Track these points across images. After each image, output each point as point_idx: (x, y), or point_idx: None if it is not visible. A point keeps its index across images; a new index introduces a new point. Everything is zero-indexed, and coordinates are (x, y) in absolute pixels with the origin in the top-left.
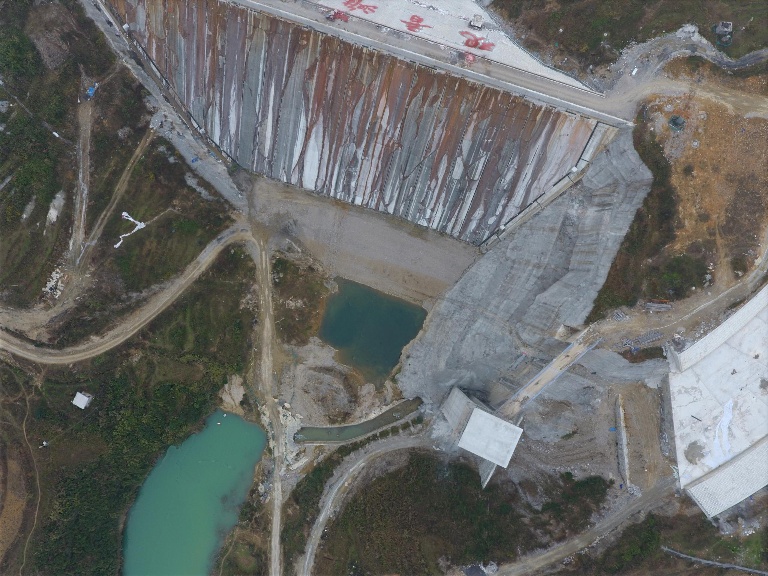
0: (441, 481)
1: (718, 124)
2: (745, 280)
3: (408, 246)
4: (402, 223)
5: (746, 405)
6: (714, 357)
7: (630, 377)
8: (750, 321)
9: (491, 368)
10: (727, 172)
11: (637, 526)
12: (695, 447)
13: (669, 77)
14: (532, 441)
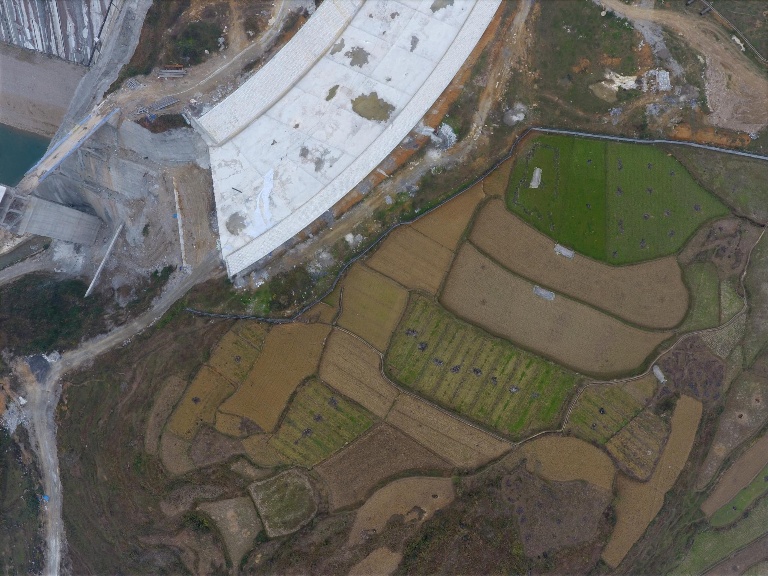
0: (37, 291)
1: None
2: (259, 40)
3: (20, 72)
4: (9, 48)
5: (287, 174)
6: (254, 129)
7: (180, 158)
8: (289, 91)
9: (69, 171)
10: None
11: (180, 298)
12: (236, 218)
13: None
14: (132, 248)
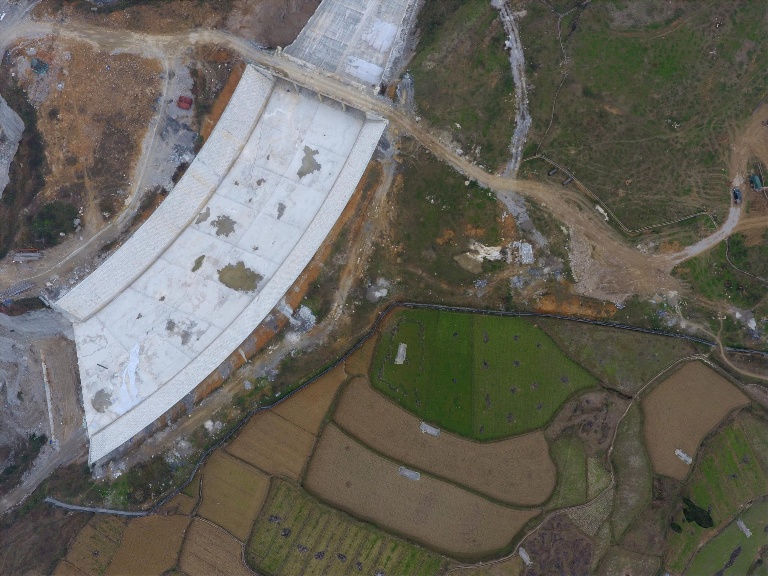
0: None
1: (83, 63)
2: (115, 221)
3: None
4: None
5: (153, 348)
6: (119, 303)
7: (46, 331)
8: (154, 263)
9: None
10: (93, 112)
11: (45, 480)
12: (102, 395)
13: (33, 19)
14: (13, 406)
